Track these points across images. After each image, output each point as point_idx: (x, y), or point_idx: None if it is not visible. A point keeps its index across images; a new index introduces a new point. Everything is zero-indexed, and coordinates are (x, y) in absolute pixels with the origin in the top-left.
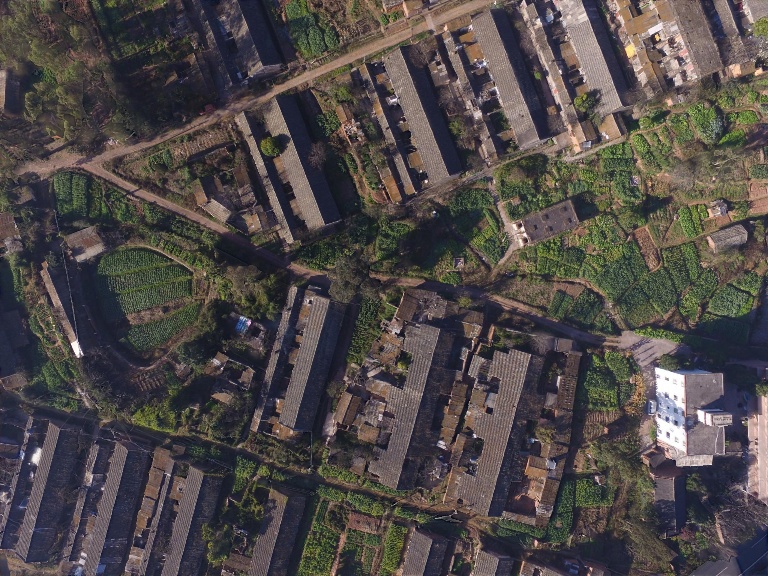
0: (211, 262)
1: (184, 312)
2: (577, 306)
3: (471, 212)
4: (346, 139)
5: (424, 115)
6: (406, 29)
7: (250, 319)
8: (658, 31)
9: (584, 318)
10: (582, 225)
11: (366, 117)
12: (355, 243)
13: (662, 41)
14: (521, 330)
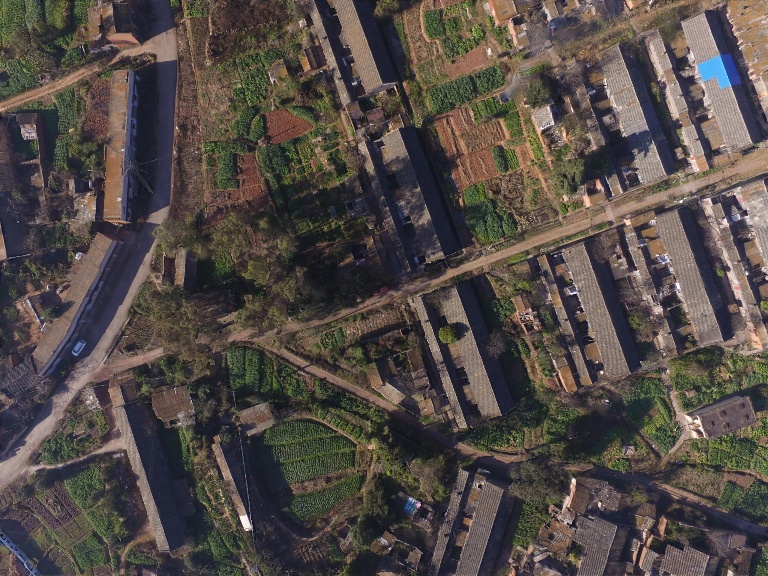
0: (385, 446)
1: (347, 483)
2: (748, 498)
3: (643, 400)
4: (520, 324)
5: (606, 311)
6: (585, 219)
7: (420, 501)
8: None
9: (754, 510)
10: None
11: (542, 305)
12: (524, 426)
13: None
14: (694, 525)
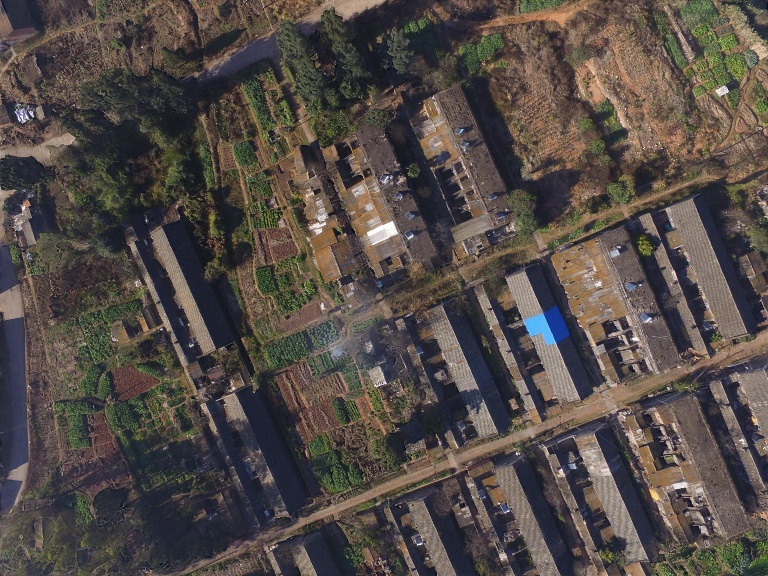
0: None
1: None
2: None
3: None
4: (373, 569)
5: (450, 564)
6: (428, 466)
7: None
8: (683, 487)
9: None
10: None
11: (392, 551)
12: None
13: (687, 493)
14: None
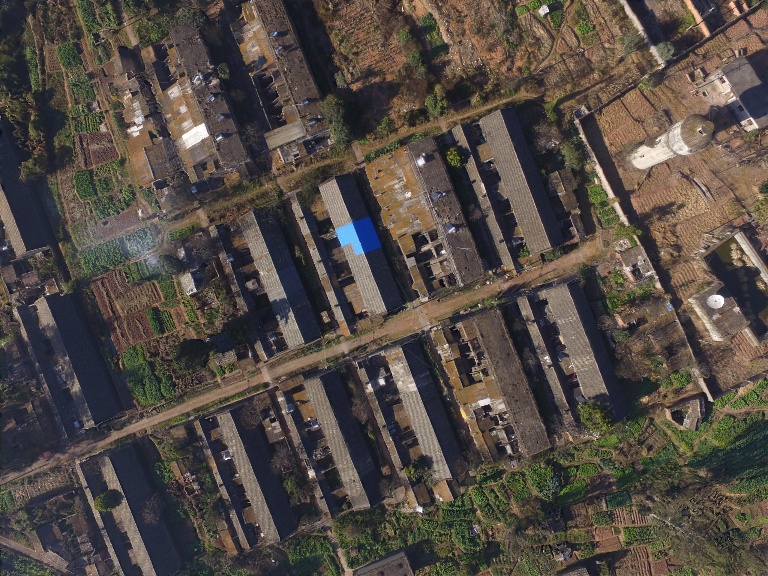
0: None
1: None
2: None
3: (311, 557)
4: None
5: (255, 479)
6: (242, 380)
7: None
8: None
9: None
10: (423, 571)
11: (203, 467)
12: None
13: None
14: None
